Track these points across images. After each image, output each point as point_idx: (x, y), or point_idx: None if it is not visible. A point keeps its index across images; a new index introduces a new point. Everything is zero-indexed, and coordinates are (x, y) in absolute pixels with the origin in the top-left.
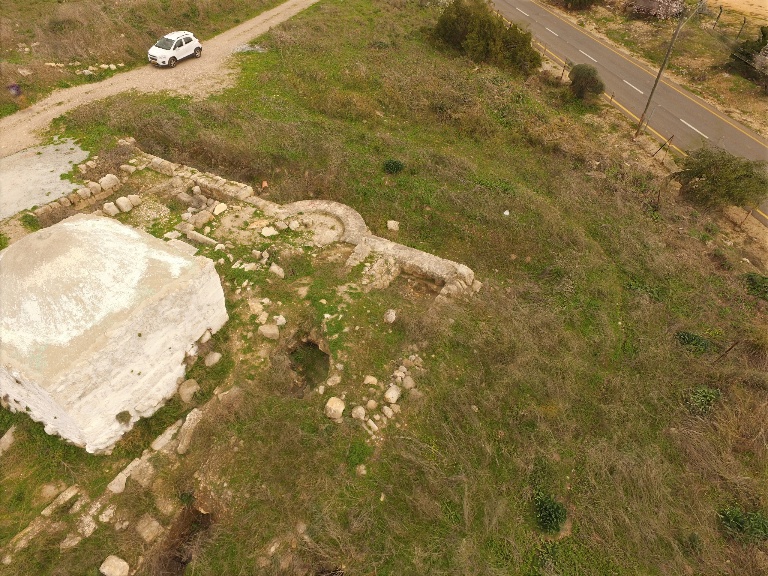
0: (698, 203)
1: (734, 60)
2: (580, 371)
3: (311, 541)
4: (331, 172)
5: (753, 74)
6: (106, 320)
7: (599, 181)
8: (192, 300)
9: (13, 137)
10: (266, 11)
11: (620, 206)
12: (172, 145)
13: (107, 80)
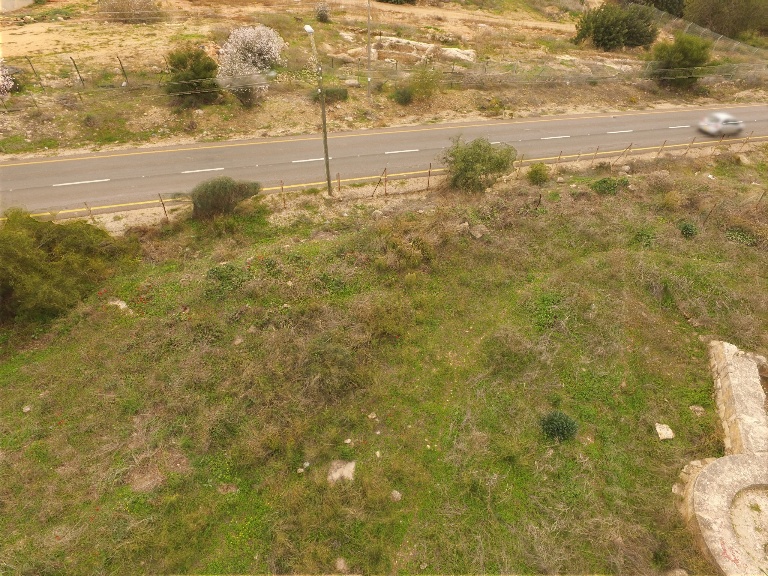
0: (481, 189)
1: (162, 97)
2: None
3: None
4: None
5: (210, 98)
6: None
7: None
8: None
9: None
10: None
11: (544, 226)
12: None
13: None
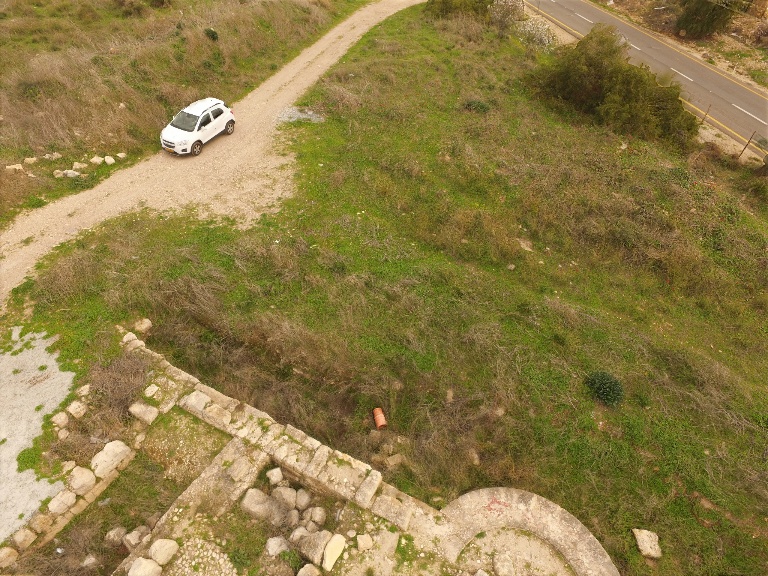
0: None
1: None
2: None
3: None
4: (500, 403)
5: None
6: None
7: None
8: None
9: None
10: (306, 48)
11: None
12: (212, 326)
13: (101, 185)
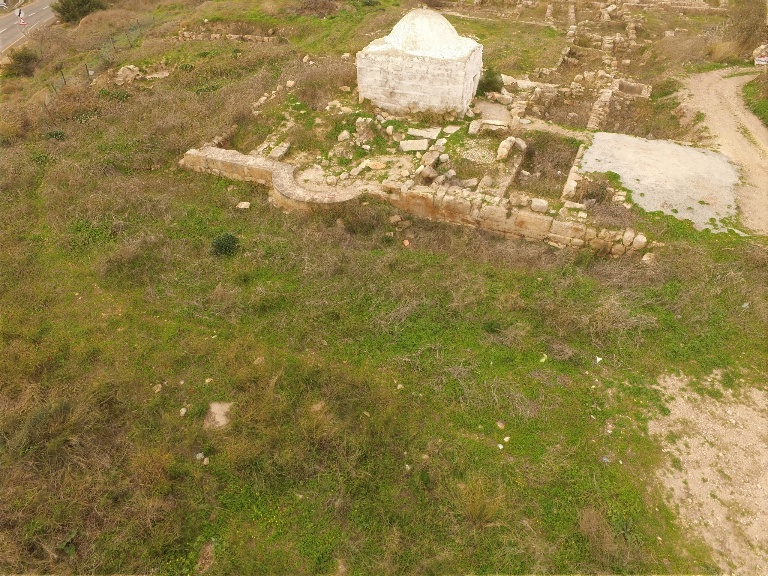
0: None
1: None
2: None
3: None
4: None
5: None
6: None
7: None
8: None
9: None
10: None
11: None
12: None
13: None
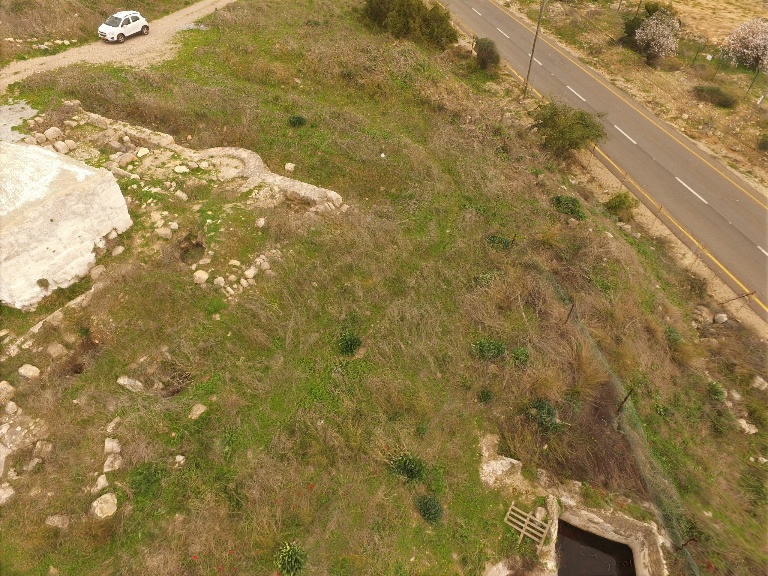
0: None
1: None
2: (400, 259)
3: (171, 356)
4: (244, 126)
5: None
6: (24, 206)
7: (468, 132)
8: (95, 201)
9: None
10: None
11: (476, 149)
12: (113, 107)
13: (61, 54)
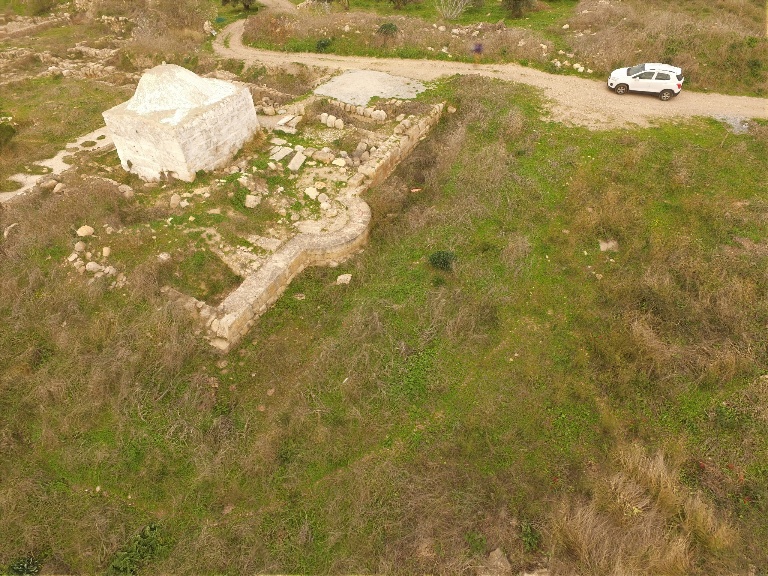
0: None
1: None
2: None
3: None
4: None
5: None
6: None
7: (463, 569)
8: (161, 142)
9: (433, 72)
10: None
11: None
12: None
13: (557, 75)
